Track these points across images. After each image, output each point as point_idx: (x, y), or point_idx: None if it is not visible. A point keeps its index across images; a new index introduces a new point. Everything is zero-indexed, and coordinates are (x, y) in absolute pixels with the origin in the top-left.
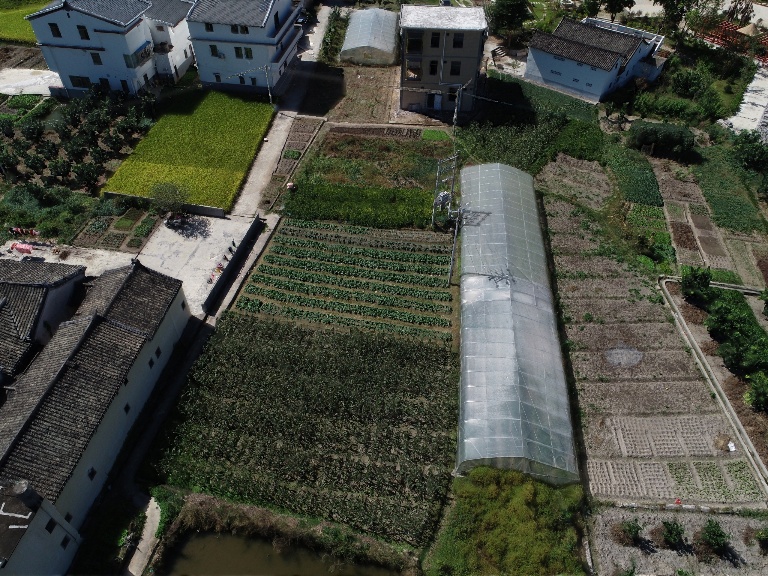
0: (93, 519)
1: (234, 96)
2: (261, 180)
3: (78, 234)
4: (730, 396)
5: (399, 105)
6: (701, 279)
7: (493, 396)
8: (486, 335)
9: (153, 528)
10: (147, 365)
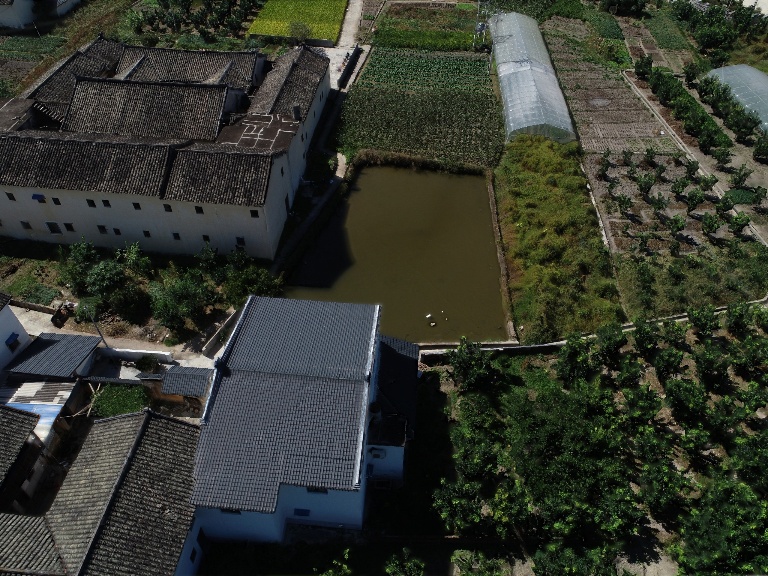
0: (308, 160)
1: None
2: (352, 30)
3: None
4: (663, 115)
5: None
6: (646, 63)
7: (525, 106)
8: (517, 85)
9: (343, 162)
10: (319, 97)
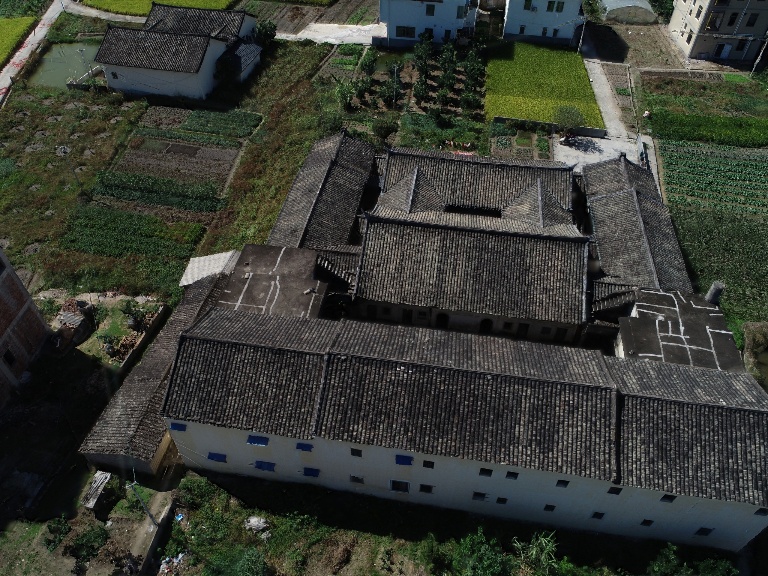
0: None
1: (539, 46)
2: (613, 111)
3: (490, 149)
4: None
5: (688, 54)
6: None
7: None
8: None
9: None
10: None
